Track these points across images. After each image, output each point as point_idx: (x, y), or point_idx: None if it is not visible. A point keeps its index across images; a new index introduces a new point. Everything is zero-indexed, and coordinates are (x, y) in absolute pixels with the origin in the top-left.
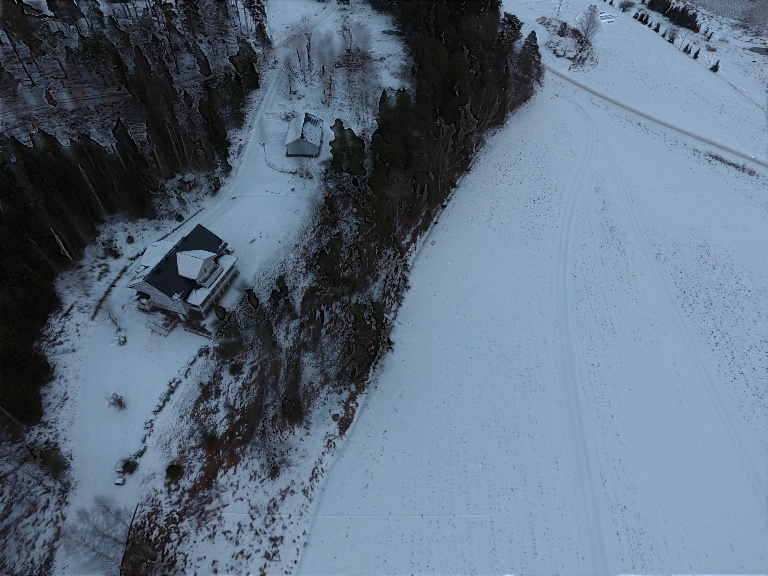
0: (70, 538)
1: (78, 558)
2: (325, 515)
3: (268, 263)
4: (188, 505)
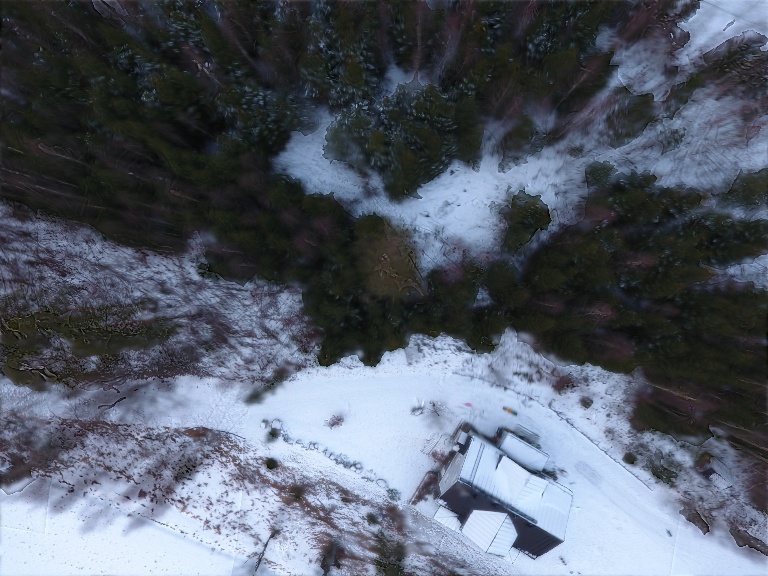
0: (228, 386)
1: (213, 394)
2: (233, 569)
3: (520, 575)
4: (247, 469)
